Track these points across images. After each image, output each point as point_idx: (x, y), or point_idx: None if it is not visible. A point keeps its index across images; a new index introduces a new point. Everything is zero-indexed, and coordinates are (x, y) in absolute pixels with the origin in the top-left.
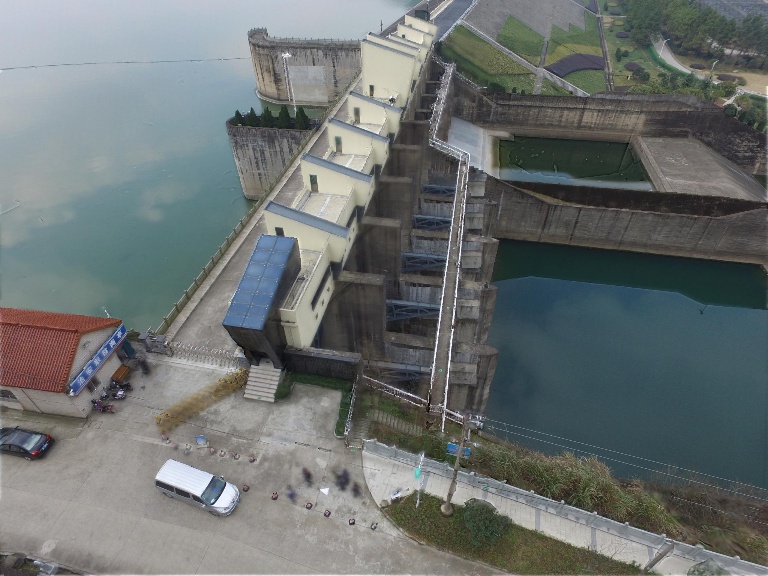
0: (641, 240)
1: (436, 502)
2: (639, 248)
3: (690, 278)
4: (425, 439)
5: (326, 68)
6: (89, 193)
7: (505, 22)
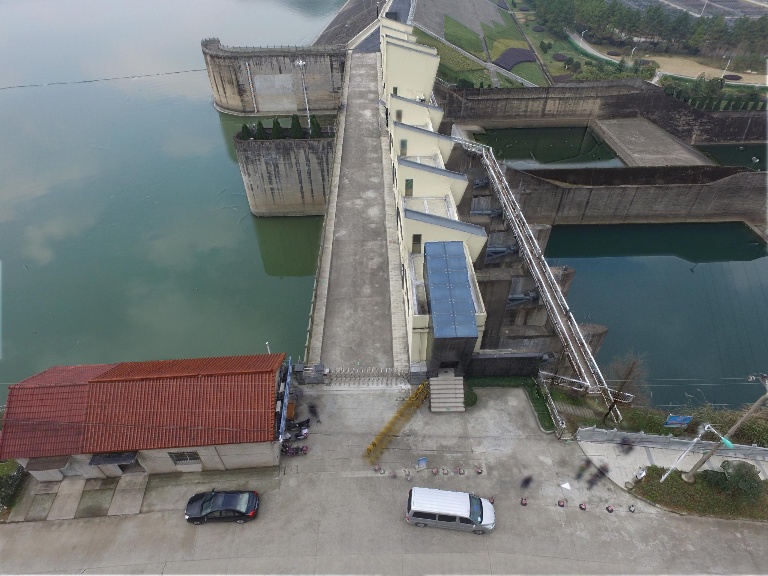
0: (644, 212)
1: (674, 473)
2: (642, 219)
3: (684, 241)
4: (638, 417)
5: (294, 76)
6: (70, 230)
7: (444, 21)
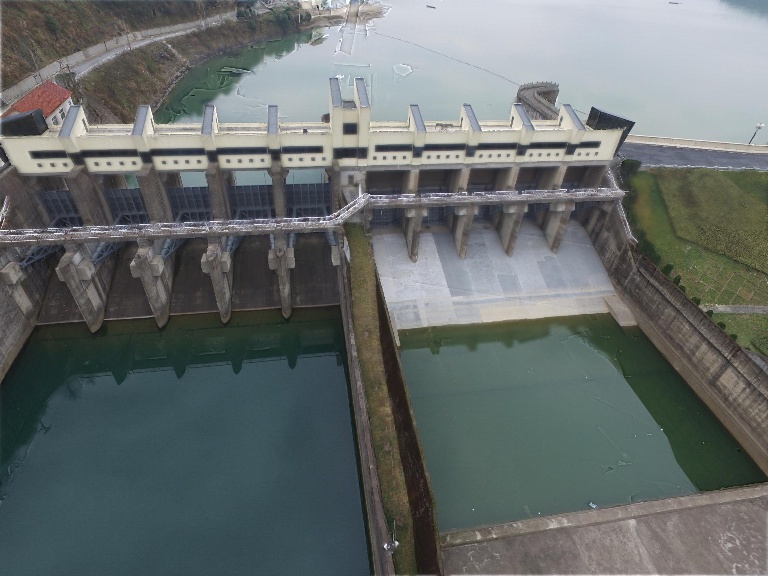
0: None
1: None
2: None
3: None
4: None
5: None
6: None
7: None
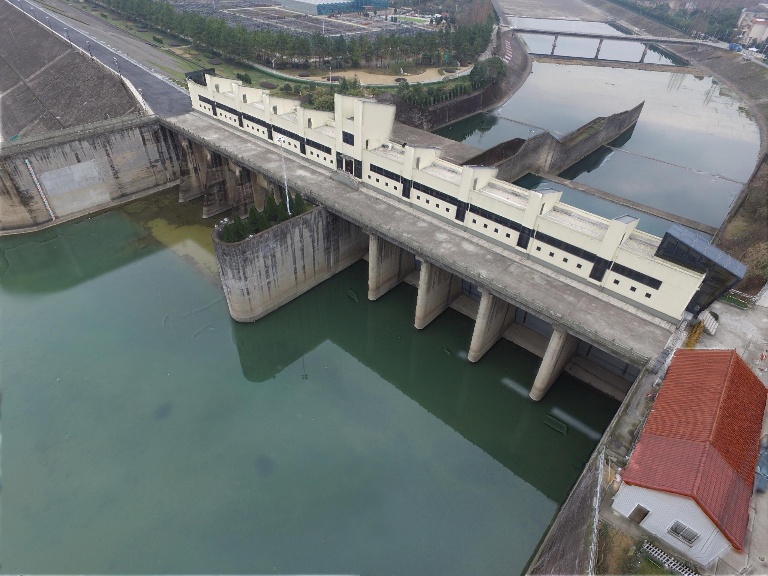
0: None
1: None
2: None
3: None
4: (759, 276)
5: (97, 160)
6: (3, 489)
7: None
